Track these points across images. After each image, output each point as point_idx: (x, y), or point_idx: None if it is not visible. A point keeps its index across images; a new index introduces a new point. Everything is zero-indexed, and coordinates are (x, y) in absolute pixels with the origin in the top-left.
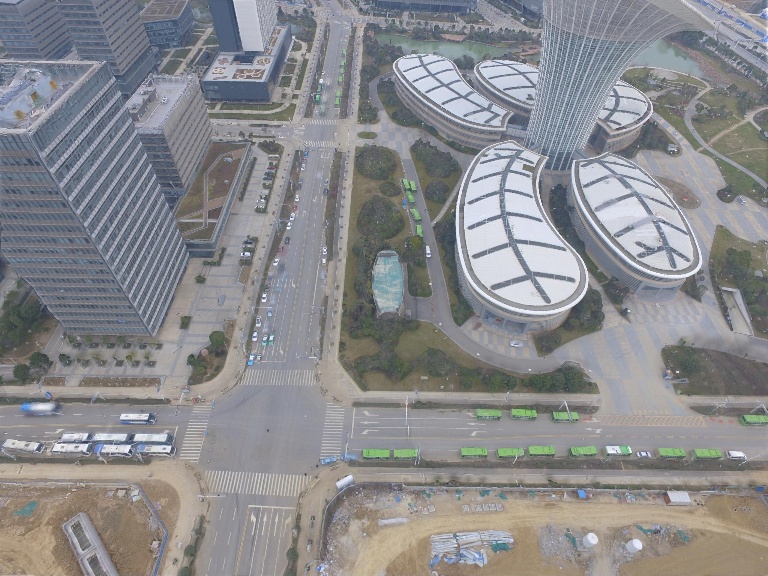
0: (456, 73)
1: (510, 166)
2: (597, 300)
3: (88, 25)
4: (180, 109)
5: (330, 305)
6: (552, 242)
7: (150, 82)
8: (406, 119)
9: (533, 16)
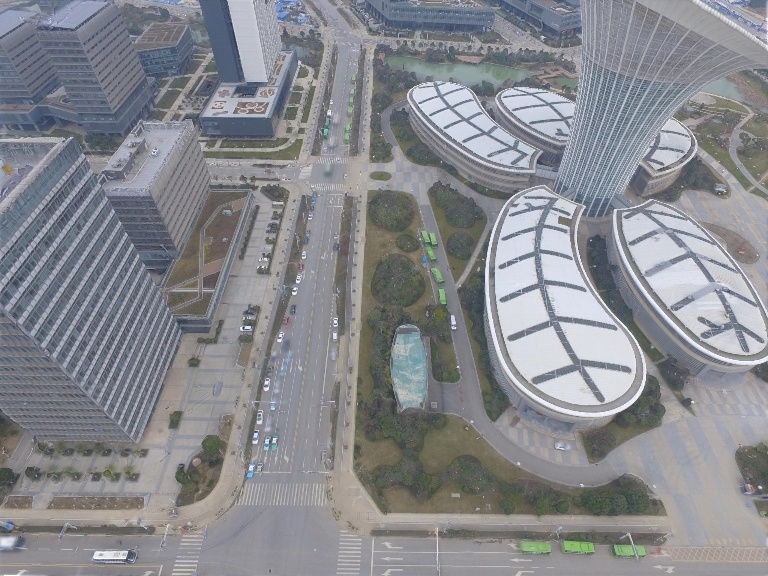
0: (476, 104)
1: (544, 220)
2: (655, 389)
3: (75, 62)
4: (172, 163)
5: (342, 394)
6: (600, 319)
7: (140, 130)
8: (422, 156)
9: (553, 34)
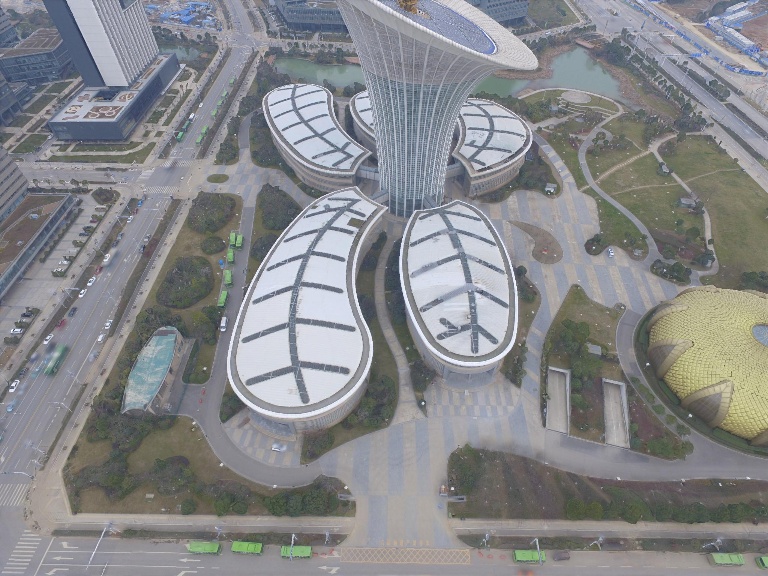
0: (326, 106)
1: (333, 221)
2: (387, 390)
3: None
4: None
5: (85, 396)
6: (341, 320)
7: None
8: (265, 159)
9: None
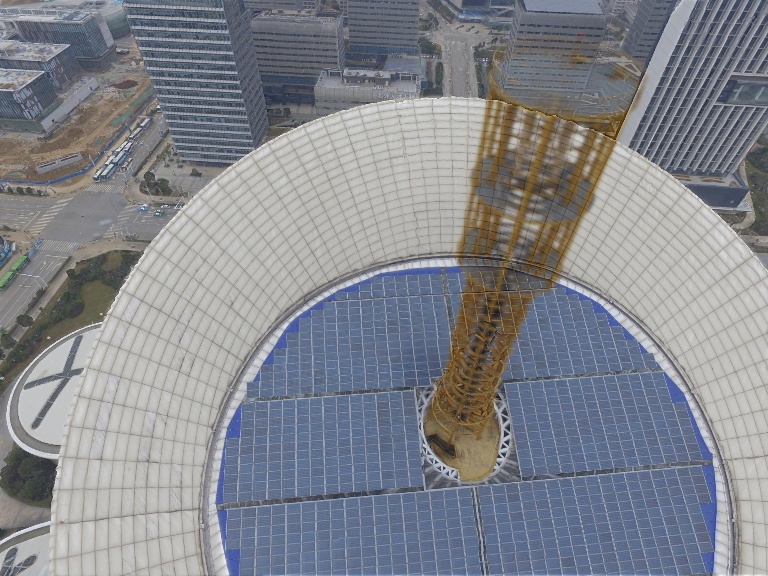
0: None
1: None
2: None
3: None
4: (359, 95)
5: None
6: None
7: (410, 77)
8: None
9: None
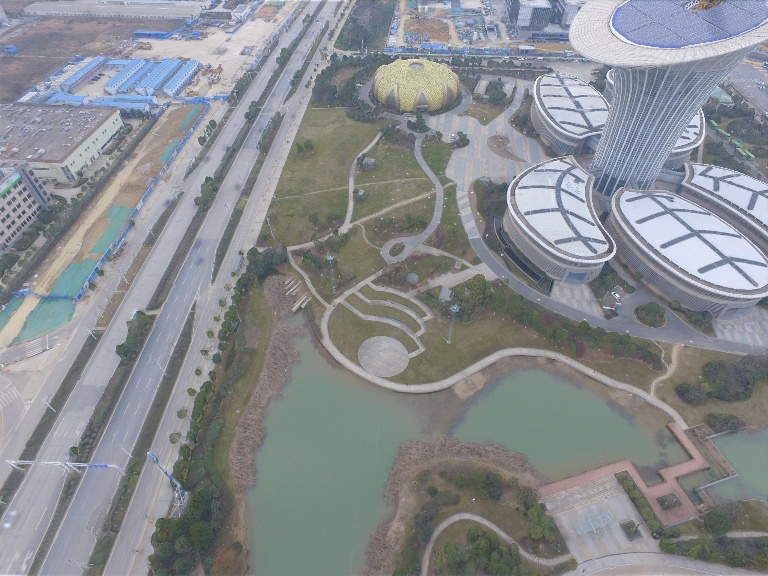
0: None
1: None
2: None
3: None
4: None
5: None
6: None
7: None
8: None
9: None
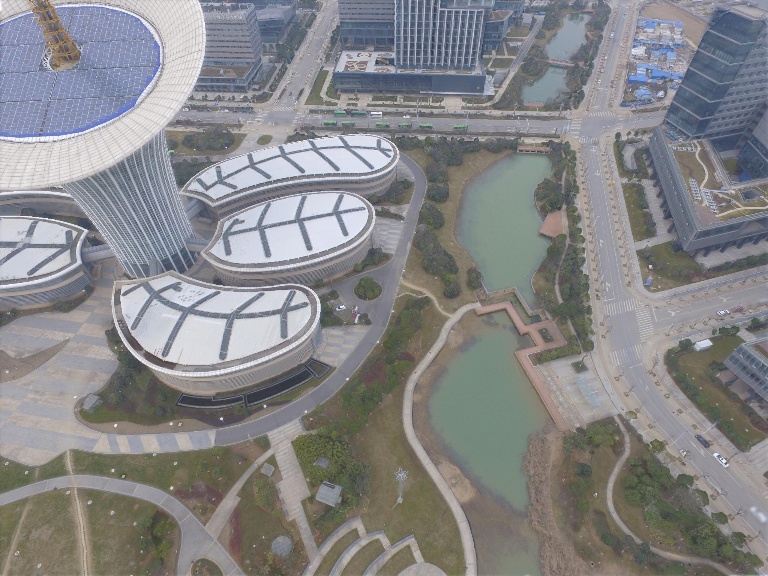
0: (327, 171)
1: None
2: None
3: None
4: None
5: None
6: None
7: (247, 7)
8: None
9: None
